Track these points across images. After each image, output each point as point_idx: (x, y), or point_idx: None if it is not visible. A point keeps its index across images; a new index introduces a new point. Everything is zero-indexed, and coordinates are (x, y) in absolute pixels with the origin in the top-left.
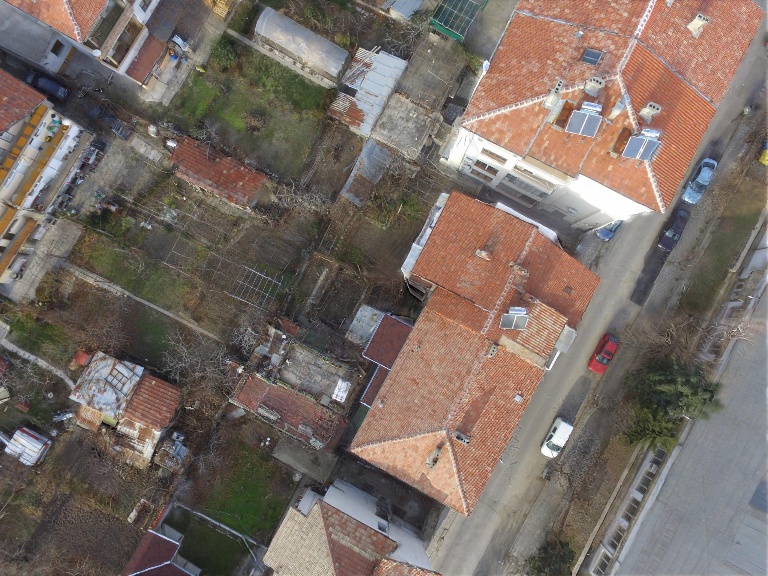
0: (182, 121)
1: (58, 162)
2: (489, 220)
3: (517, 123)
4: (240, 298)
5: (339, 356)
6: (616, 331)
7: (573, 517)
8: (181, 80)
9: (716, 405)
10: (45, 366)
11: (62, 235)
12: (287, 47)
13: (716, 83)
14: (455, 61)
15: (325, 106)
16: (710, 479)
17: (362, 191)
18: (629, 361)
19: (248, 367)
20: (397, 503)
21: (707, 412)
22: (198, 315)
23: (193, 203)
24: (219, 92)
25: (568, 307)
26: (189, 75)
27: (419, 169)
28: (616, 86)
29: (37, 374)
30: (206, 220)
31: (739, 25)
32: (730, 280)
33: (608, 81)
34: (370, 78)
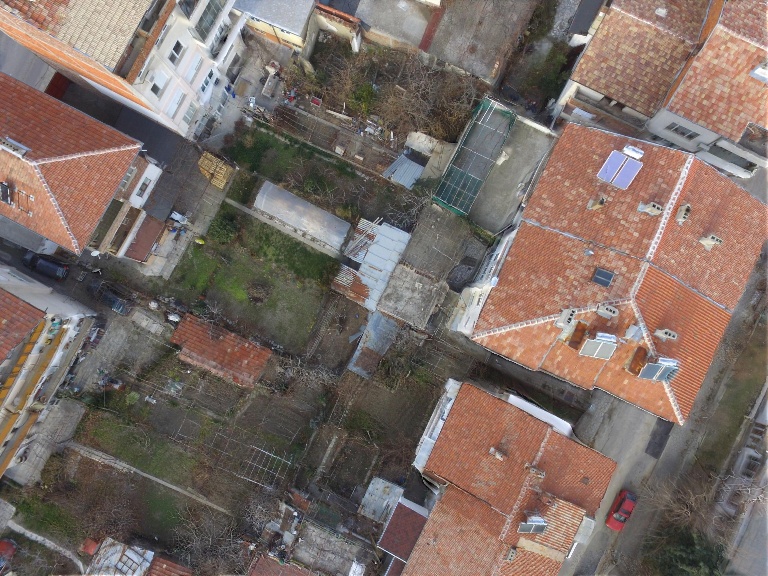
0: (183, 294)
1: (59, 354)
2: (502, 416)
3: (529, 339)
4: (249, 479)
5: (352, 531)
6: (632, 485)
7: None
8: (181, 253)
9: (738, 567)
10: (53, 547)
11: (66, 422)
12: (288, 221)
13: (730, 290)
14: (460, 236)
15: (329, 281)
16: None
17: (369, 364)
18: (647, 516)
19: (260, 544)
20: None
21: (729, 575)
22: (207, 489)
23: (197, 375)
24: (220, 264)
25: (585, 496)
26: (189, 247)
27: (426, 337)
28: (630, 310)
29: (45, 557)
30: (211, 392)
31: (752, 230)
32: (746, 427)
33: (621, 305)
34: (373, 251)
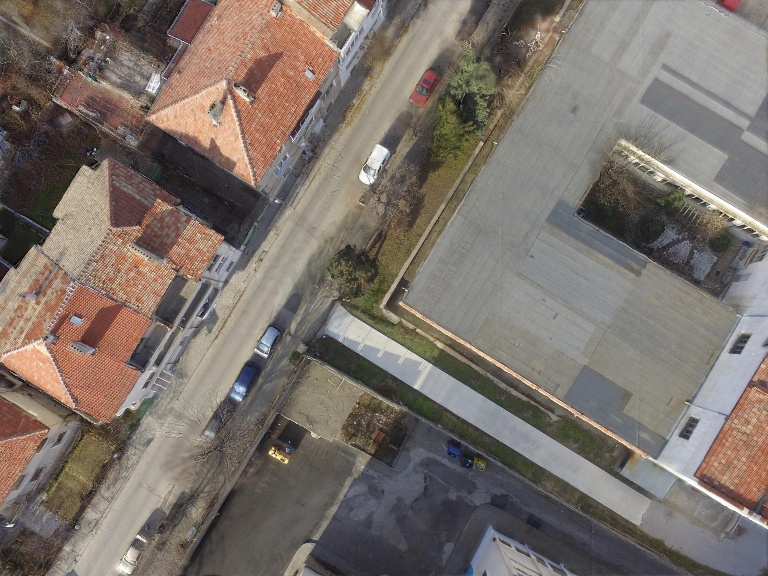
0: None
1: None
2: None
3: None
4: None
5: (161, 61)
6: (439, 68)
7: (388, 247)
8: None
9: (520, 127)
10: None
11: None
12: None
13: None
14: None
15: None
16: (509, 196)
17: None
18: None
19: (73, 68)
20: (219, 223)
21: (511, 133)
22: (31, 21)
23: None
24: None
25: None
26: None
27: None
28: None
29: None
30: None
31: None
32: (554, 29)
33: None
34: None
